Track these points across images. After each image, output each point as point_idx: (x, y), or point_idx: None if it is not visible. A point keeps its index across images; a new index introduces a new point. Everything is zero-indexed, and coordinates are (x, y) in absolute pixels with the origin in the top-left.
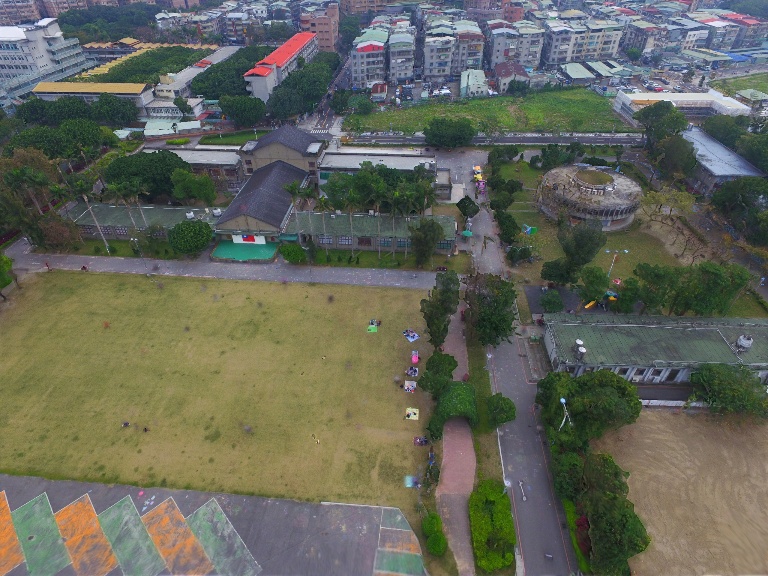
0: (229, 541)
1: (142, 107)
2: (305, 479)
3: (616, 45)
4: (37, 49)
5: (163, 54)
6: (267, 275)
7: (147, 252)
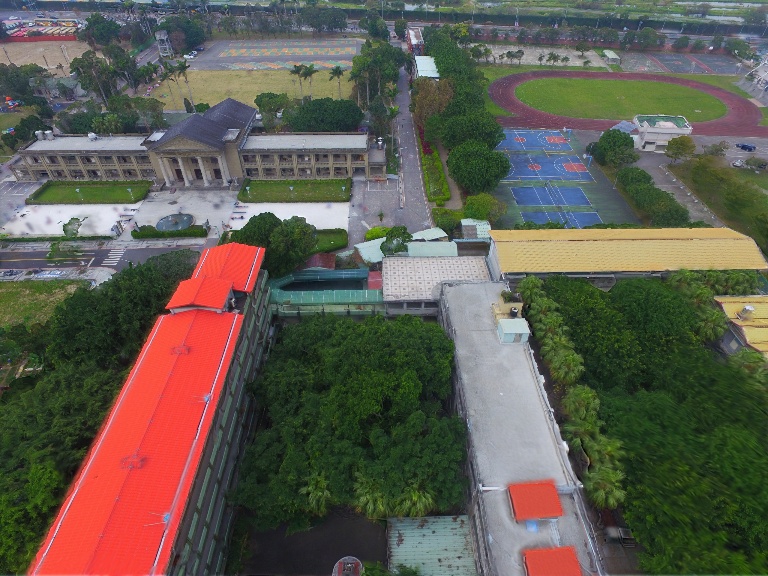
0: None
1: None
2: None
3: None
4: None
5: None
6: None
7: None
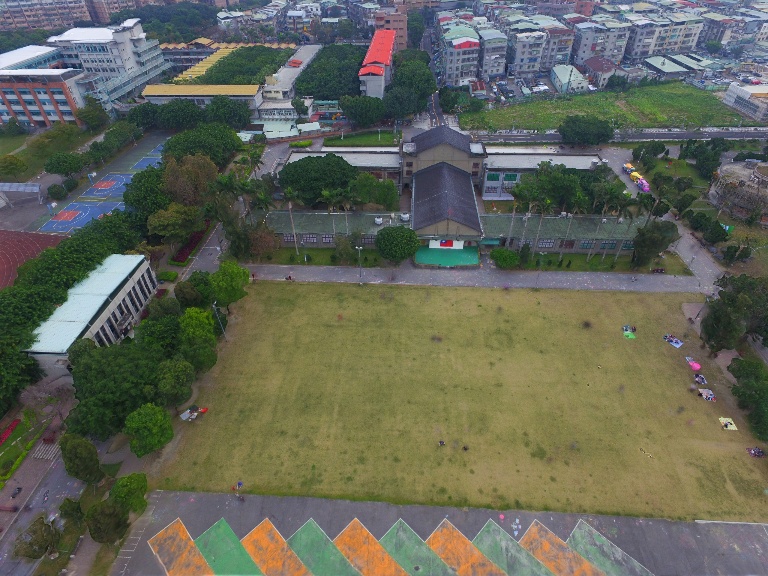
0: (628, 565)
1: (255, 109)
2: (663, 496)
3: (696, 38)
4: (125, 51)
5: (249, 54)
6: (483, 281)
7: (346, 260)
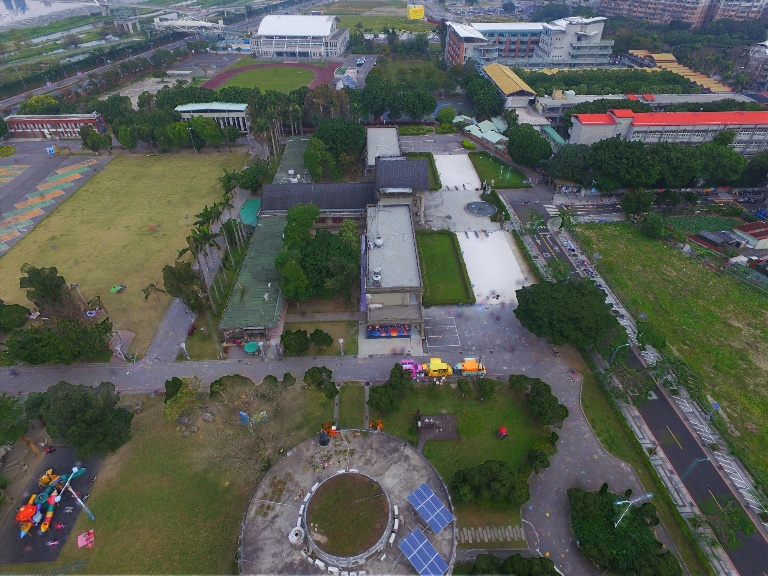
0: None
1: None
2: None
3: None
4: (562, 41)
5: (641, 76)
6: None
7: None
